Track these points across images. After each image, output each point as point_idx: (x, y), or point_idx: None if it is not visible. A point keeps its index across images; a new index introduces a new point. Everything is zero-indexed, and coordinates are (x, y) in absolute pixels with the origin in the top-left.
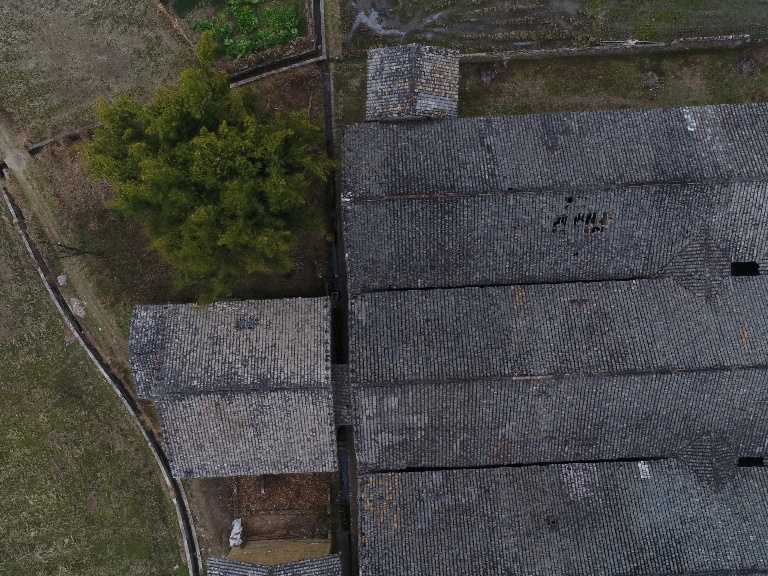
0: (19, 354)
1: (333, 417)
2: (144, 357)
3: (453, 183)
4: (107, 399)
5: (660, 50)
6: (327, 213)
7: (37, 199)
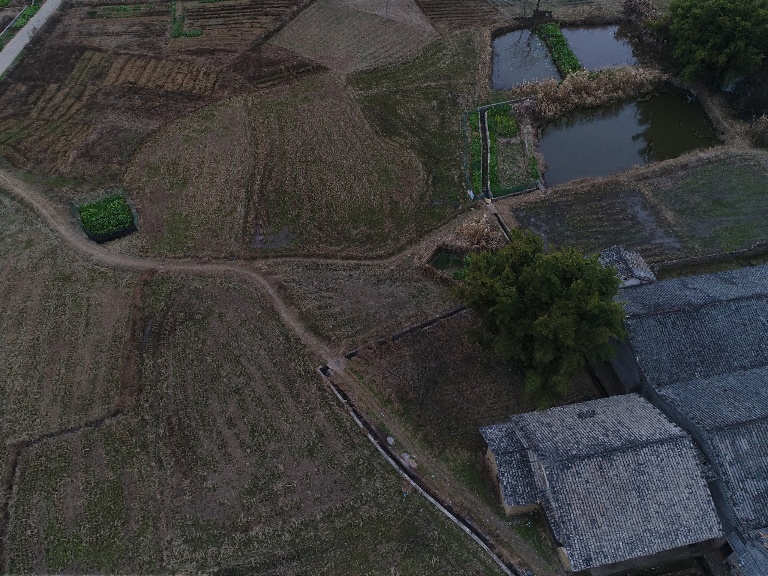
0: (360, 512)
1: (701, 469)
2: (509, 456)
3: (688, 302)
4: (454, 542)
5: (746, 255)
6: (585, 368)
7: (358, 386)
